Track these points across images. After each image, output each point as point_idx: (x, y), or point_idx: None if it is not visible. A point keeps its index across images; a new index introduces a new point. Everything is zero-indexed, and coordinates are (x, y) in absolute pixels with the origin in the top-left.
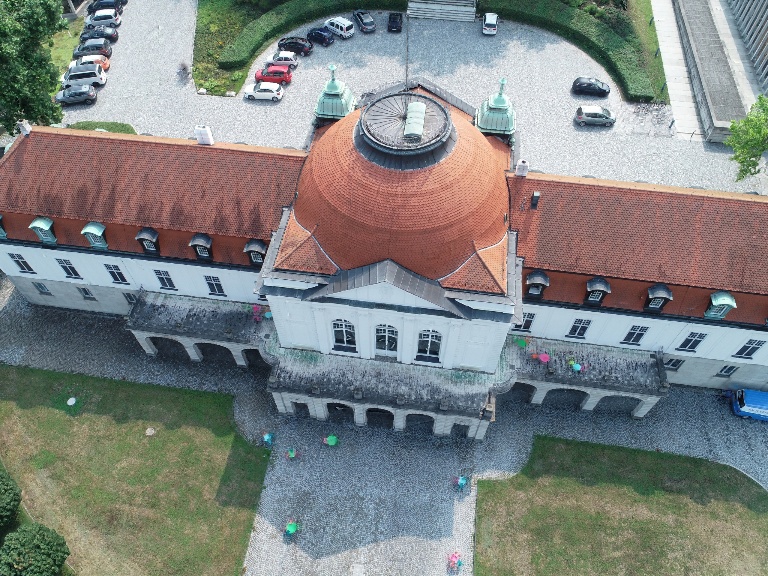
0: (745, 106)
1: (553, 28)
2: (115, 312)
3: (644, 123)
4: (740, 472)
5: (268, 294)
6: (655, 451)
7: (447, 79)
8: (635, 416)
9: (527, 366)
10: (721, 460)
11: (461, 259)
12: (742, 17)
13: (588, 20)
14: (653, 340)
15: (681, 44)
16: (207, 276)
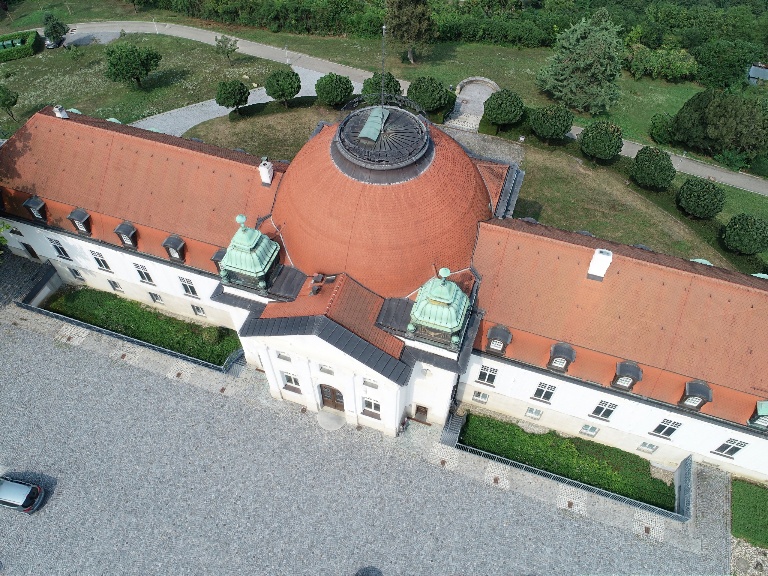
0: None
1: None
2: None
3: None
4: None
5: None
6: None
7: None
8: None
9: None
10: None
11: None
12: None
13: None
14: None
15: None
16: None
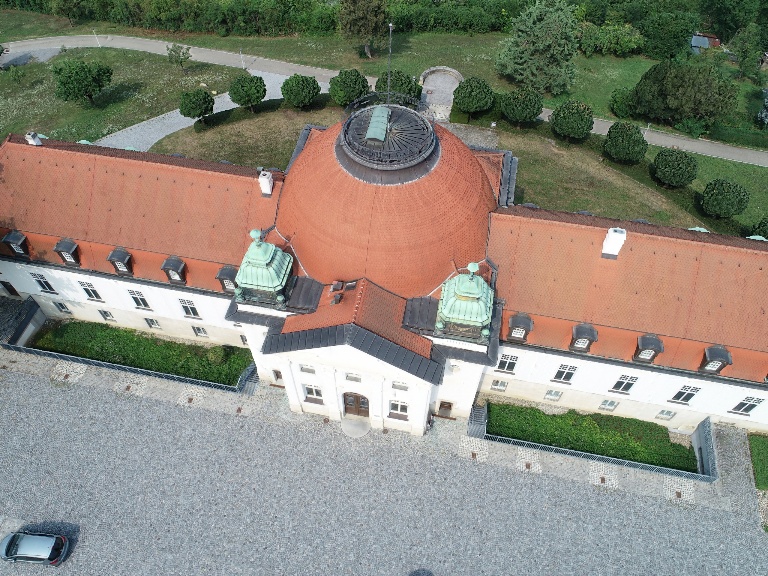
0: None
1: None
2: None
3: None
4: None
5: None
6: None
7: None
8: None
9: None
10: None
11: None
12: None
13: None
14: None
15: None
16: None
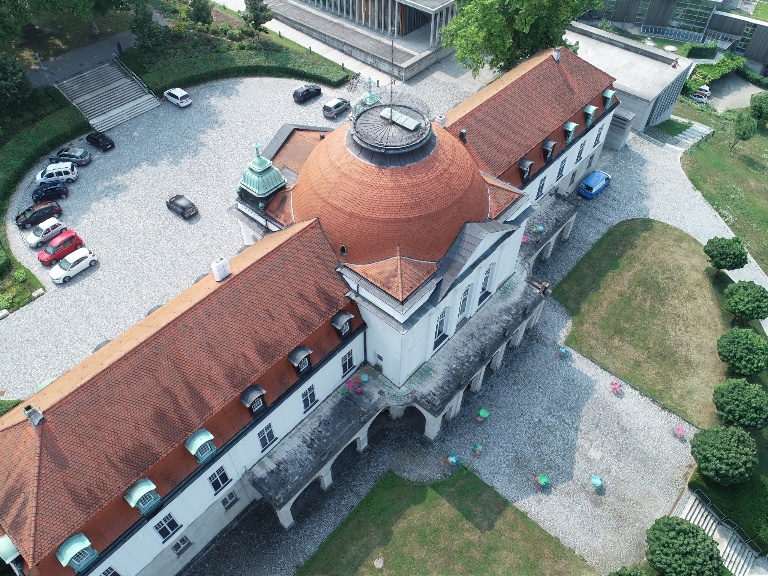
0: (401, 49)
1: (225, 75)
2: (209, 540)
3: (363, 93)
4: (625, 220)
5: (413, 325)
6: (592, 246)
7: (207, 151)
8: (566, 239)
9: (520, 253)
10: (614, 223)
11: (486, 193)
12: (327, 4)
13: (247, 54)
14: (547, 184)
15: (314, 39)
16: (304, 392)
